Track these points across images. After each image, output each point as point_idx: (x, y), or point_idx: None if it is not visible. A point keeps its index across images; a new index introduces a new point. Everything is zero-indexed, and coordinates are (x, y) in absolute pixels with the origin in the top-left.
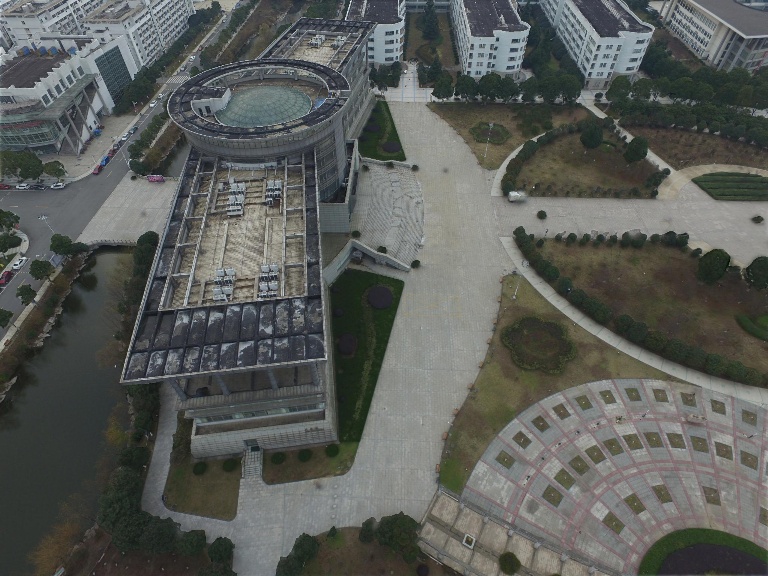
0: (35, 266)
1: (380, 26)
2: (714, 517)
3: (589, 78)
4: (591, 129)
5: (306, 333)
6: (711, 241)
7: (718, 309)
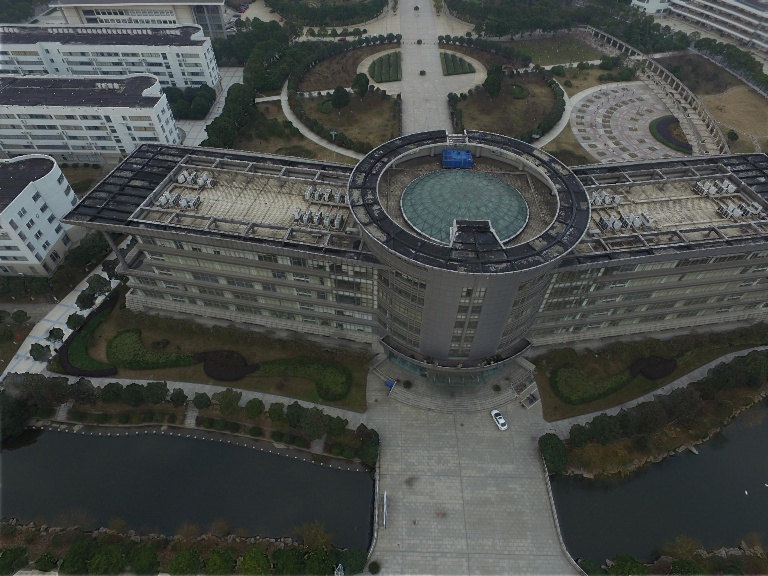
0: (703, 574)
1: (47, 178)
2: (644, 131)
3: (214, 87)
4: (342, 91)
5: (752, 162)
6: (446, 91)
7: (509, 102)
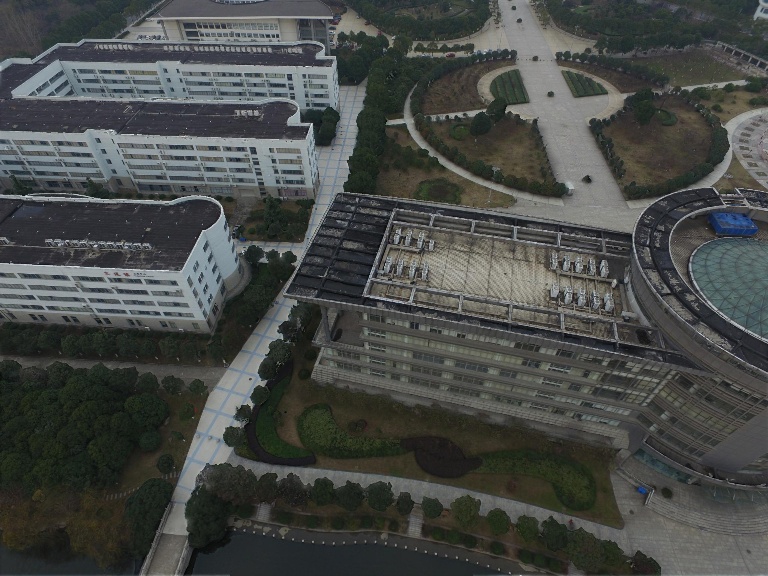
0: None
1: (217, 225)
2: None
3: (336, 109)
4: (485, 118)
5: None
6: (583, 116)
7: (658, 129)
